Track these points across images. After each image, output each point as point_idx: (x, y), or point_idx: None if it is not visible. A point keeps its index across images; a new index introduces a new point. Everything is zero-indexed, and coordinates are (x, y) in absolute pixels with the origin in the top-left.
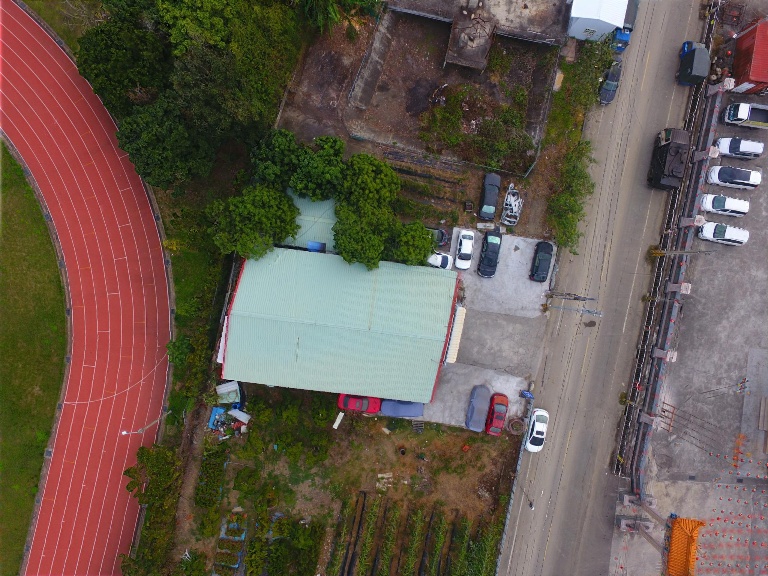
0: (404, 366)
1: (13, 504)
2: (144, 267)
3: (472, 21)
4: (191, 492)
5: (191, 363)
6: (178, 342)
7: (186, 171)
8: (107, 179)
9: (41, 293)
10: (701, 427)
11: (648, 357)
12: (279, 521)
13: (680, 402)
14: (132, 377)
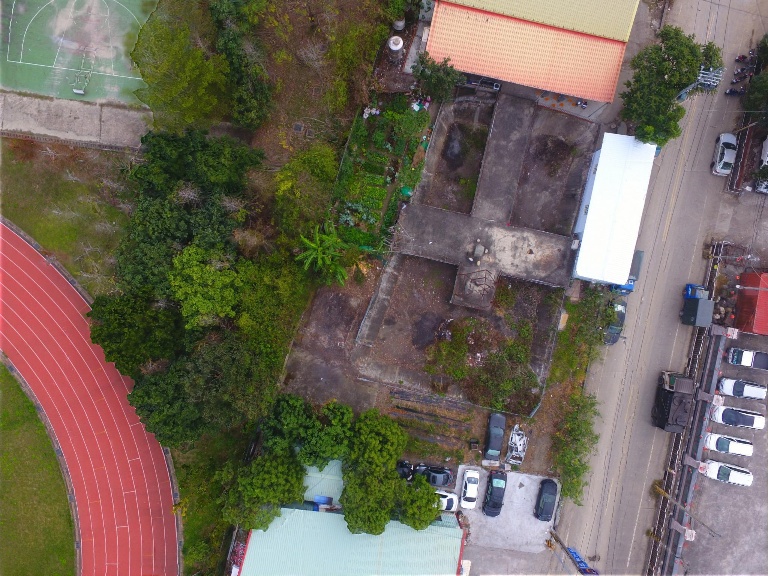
0: None
1: None
2: (153, 500)
3: (478, 268)
4: None
5: None
6: None
7: (196, 437)
8: (117, 414)
9: (51, 527)
10: None
11: None
12: None
13: None
14: None
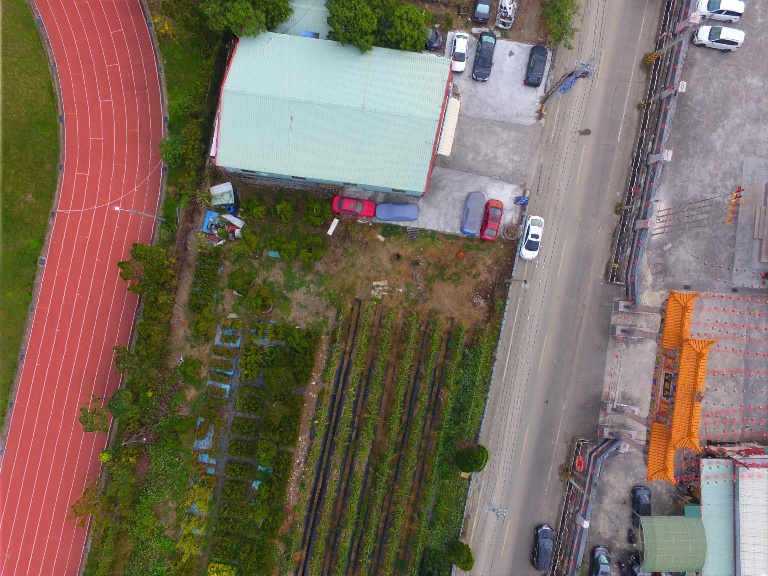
0: (398, 149)
1: (7, 312)
2: (137, 74)
3: None
4: (185, 299)
5: (184, 156)
6: (171, 138)
7: None
8: None
9: (33, 99)
10: (696, 236)
11: (643, 166)
12: (274, 326)
13: (675, 211)
14: (125, 185)
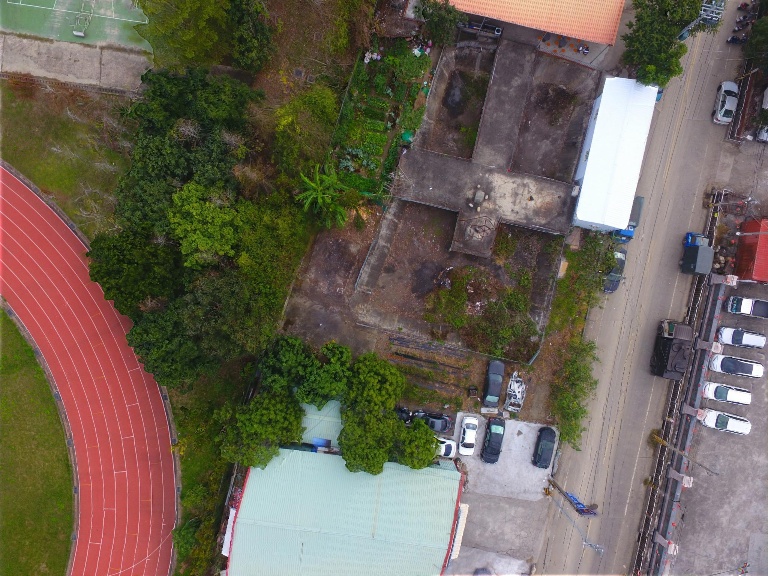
0: (407, 570)
1: None
2: (151, 446)
3: (478, 214)
4: None
5: None
6: (183, 531)
7: (194, 376)
8: (116, 359)
9: (49, 471)
10: None
11: (649, 540)
12: None
13: None
14: (137, 554)
